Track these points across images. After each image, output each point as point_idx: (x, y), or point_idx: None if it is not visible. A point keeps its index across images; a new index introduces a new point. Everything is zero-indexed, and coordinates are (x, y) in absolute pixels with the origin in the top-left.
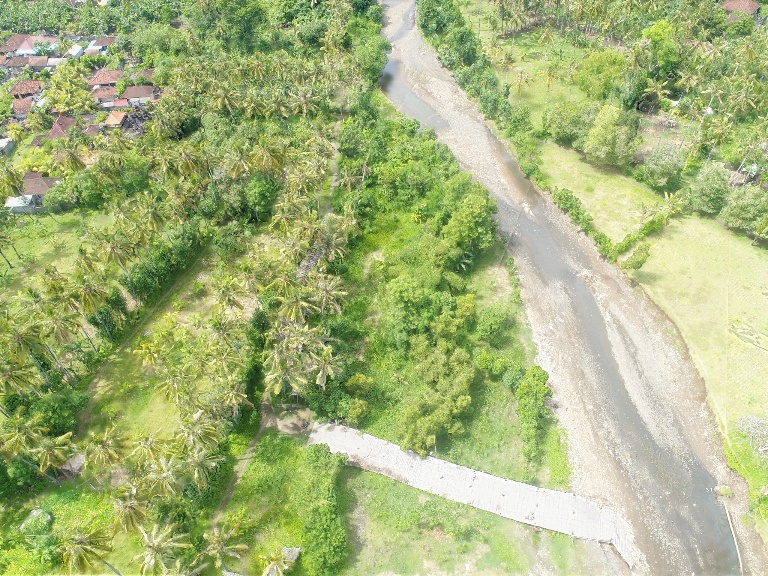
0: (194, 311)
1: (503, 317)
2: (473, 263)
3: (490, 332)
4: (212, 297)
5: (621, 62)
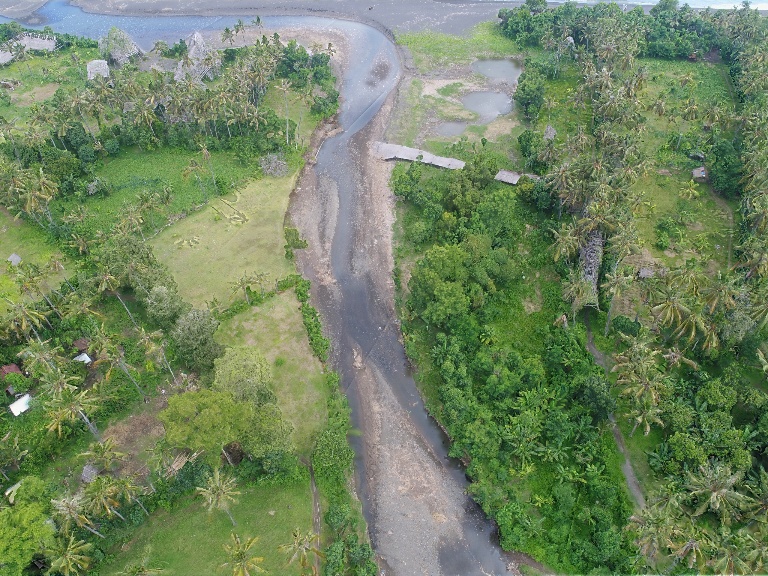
0: None
1: None
2: None
3: None
4: (649, 161)
5: None
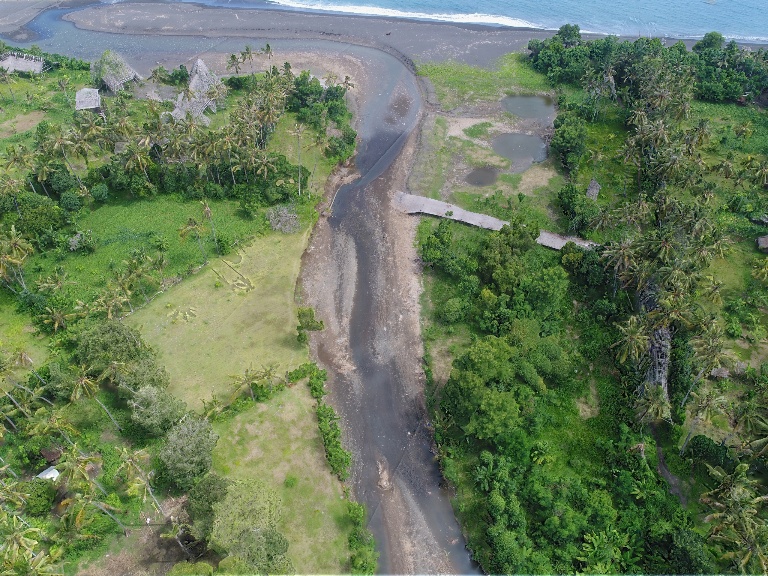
0: (766, 355)
1: None
2: None
3: None
4: None
5: None
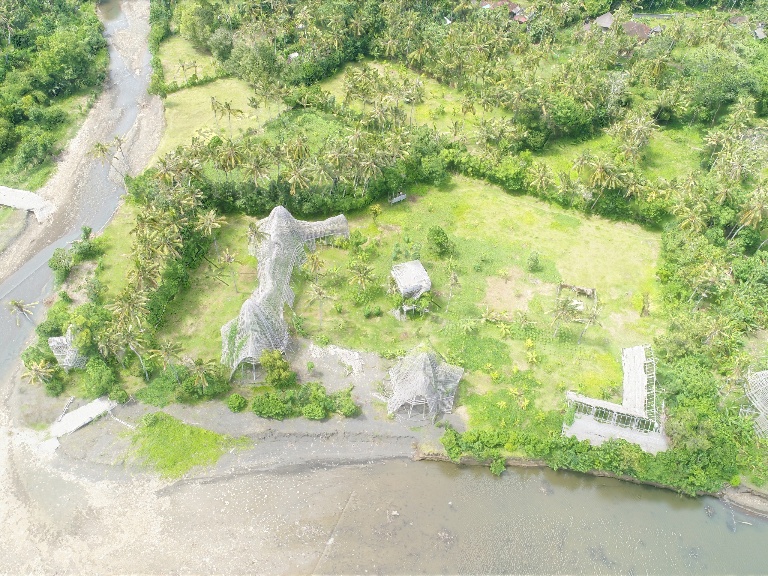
0: None
1: (54, 114)
2: (68, 93)
3: (34, 117)
4: None
5: None
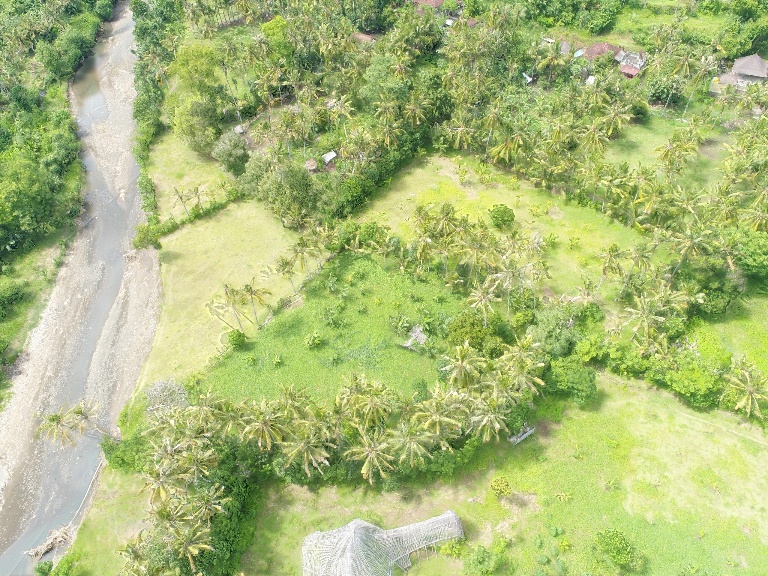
0: None
1: (6, 293)
2: (29, 245)
3: None
4: None
5: (208, 56)
